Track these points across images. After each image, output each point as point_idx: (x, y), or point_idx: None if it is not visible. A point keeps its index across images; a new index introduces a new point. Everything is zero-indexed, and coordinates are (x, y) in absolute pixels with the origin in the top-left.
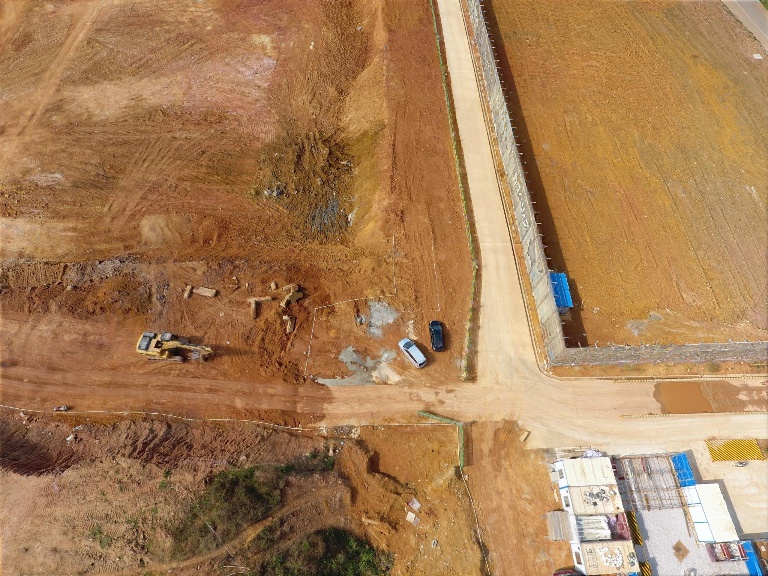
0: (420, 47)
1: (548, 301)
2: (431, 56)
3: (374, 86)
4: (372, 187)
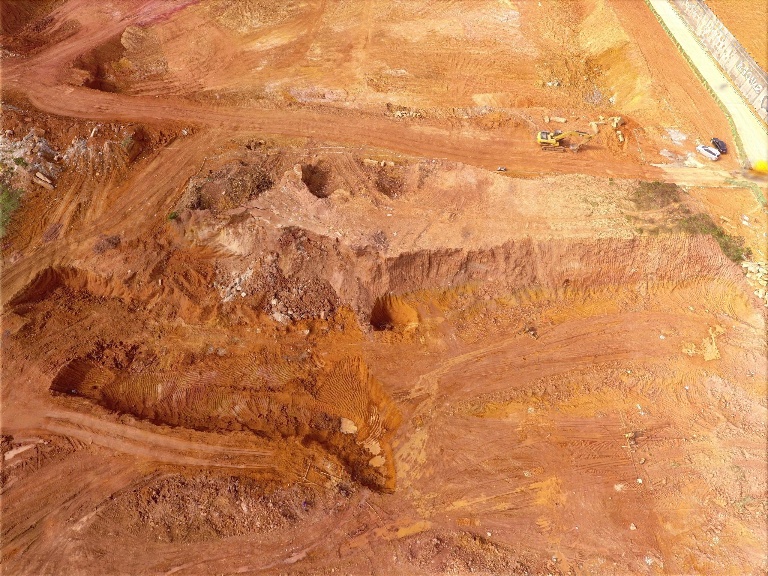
0: (632, 0)
1: None
2: (642, 5)
3: (607, 22)
4: (631, 77)
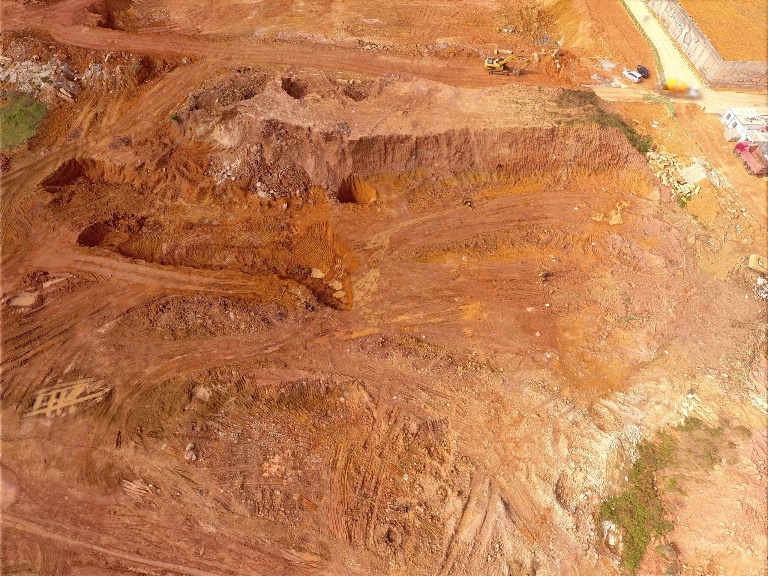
0: None
1: (706, 51)
2: None
3: None
4: (575, 22)
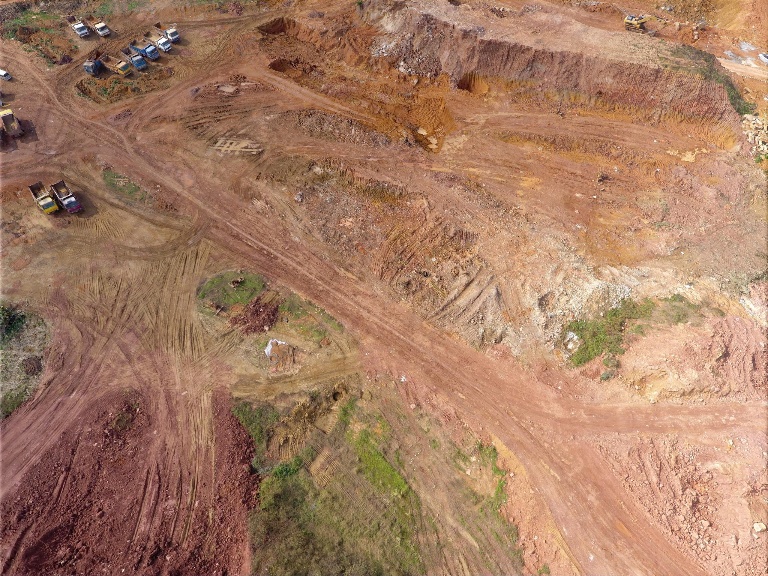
0: None
1: None
2: None
3: None
4: (735, 11)
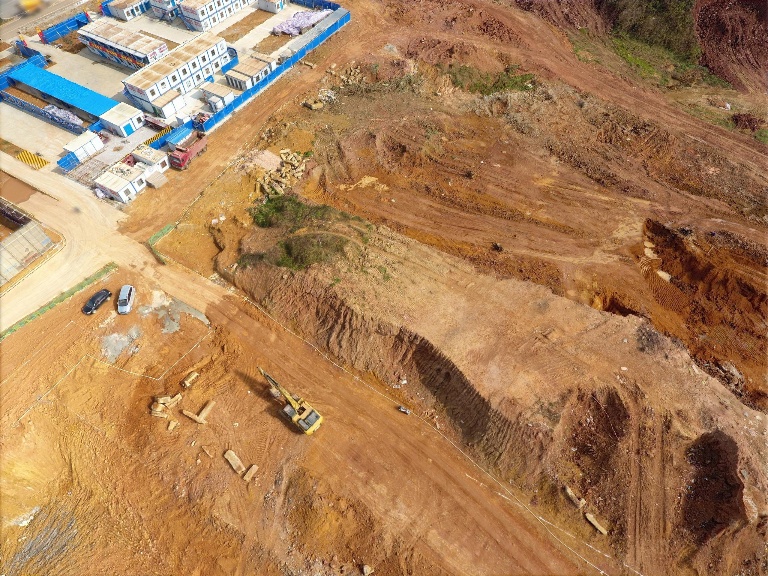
0: None
1: None
2: None
3: None
4: None
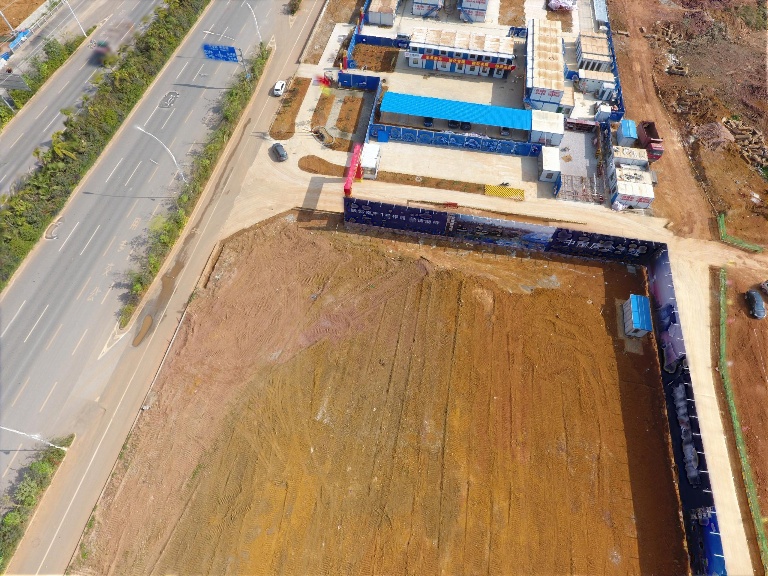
0: None
1: None
2: None
3: None
4: None
